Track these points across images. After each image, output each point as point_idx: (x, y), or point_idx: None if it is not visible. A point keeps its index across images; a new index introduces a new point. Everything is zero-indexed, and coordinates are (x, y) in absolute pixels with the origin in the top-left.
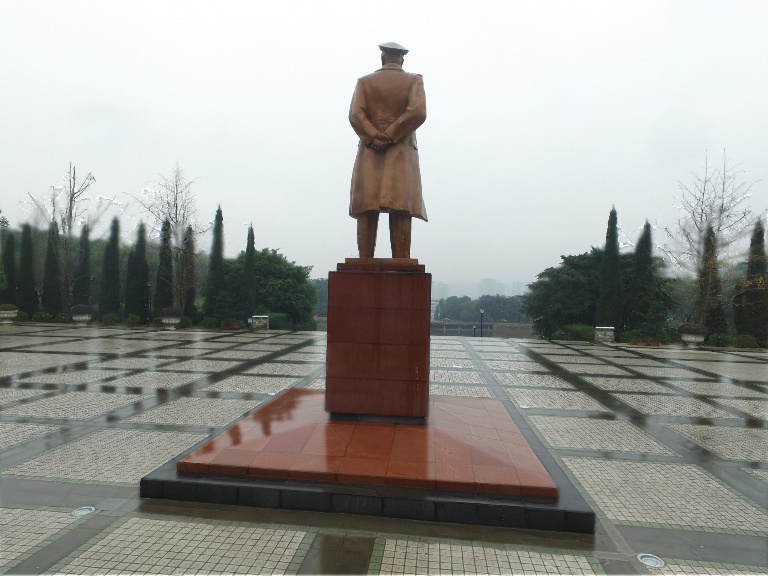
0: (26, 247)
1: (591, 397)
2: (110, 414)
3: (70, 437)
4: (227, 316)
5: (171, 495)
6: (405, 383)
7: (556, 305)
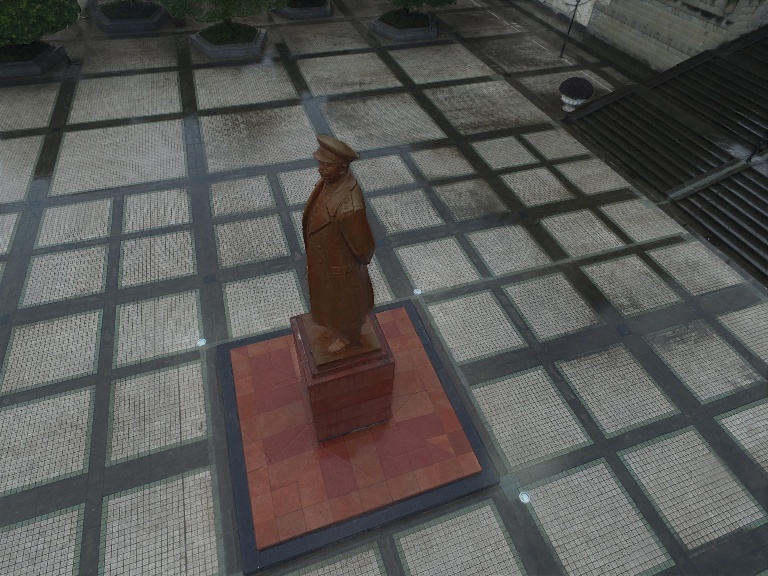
0: None
1: (144, 300)
2: None
3: None
4: None
5: None
6: None
7: None
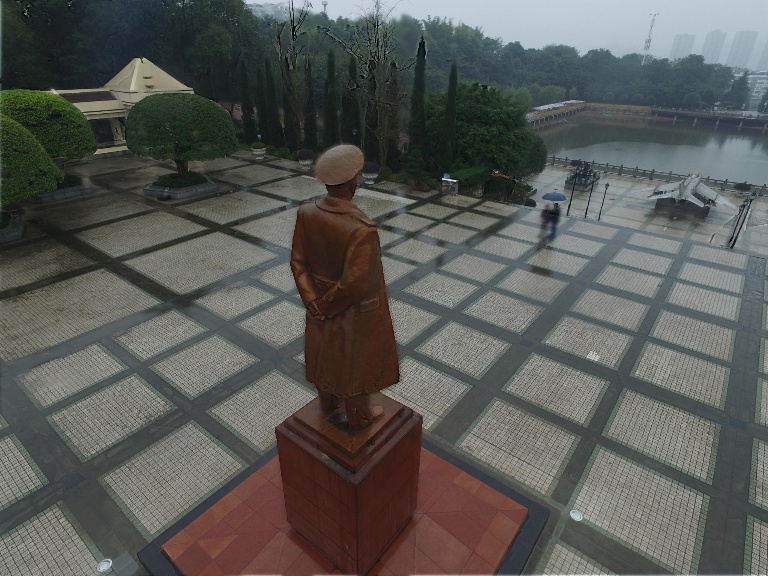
0: (269, 82)
1: (704, 521)
2: (210, 393)
3: (165, 430)
4: (418, 176)
5: (150, 575)
6: (339, 548)
7: None
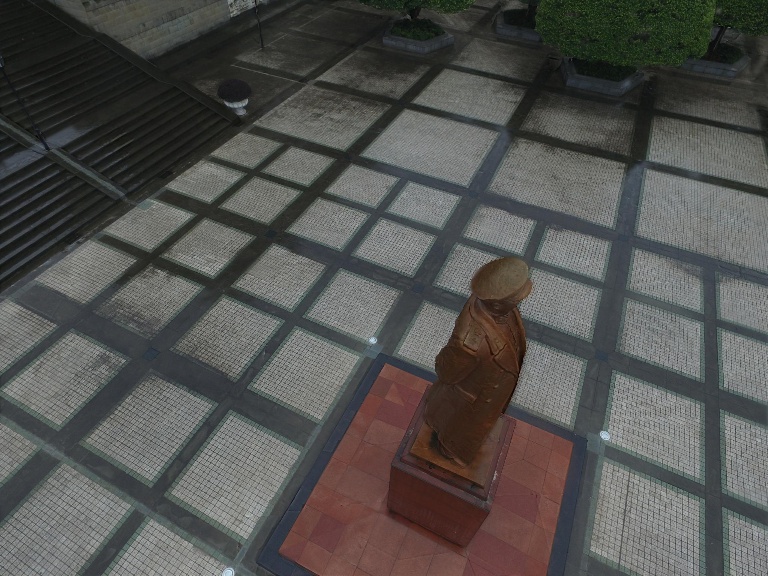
0: None
1: None
2: (528, 323)
3: None
4: None
5: None
6: None
7: None
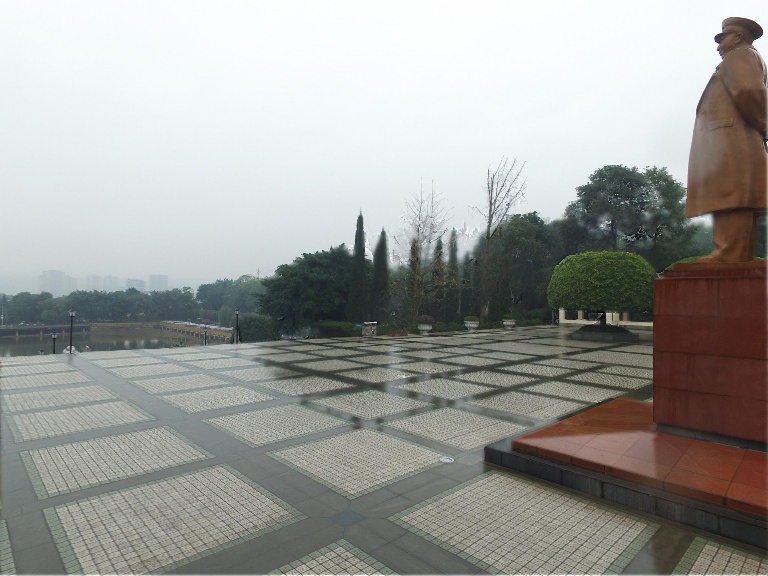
0: None
1: None
2: None
3: None
4: None
5: None
6: None
7: (310, 303)
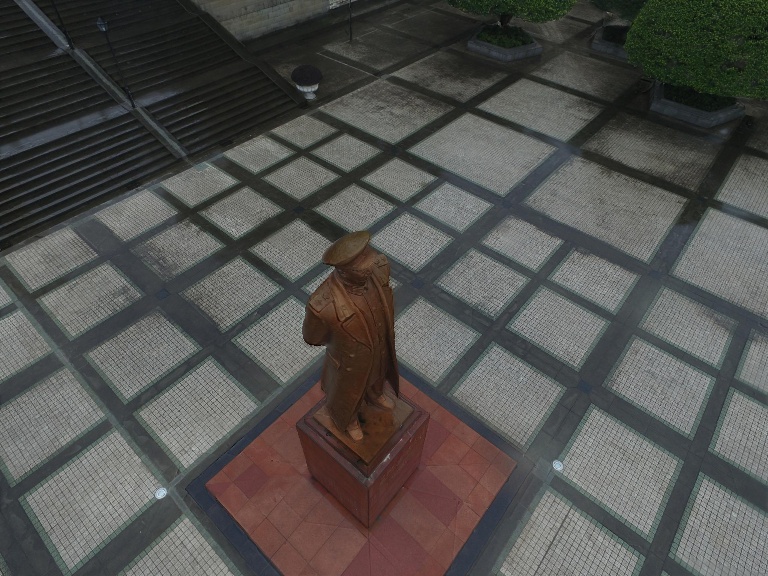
0: None
1: None
2: (517, 339)
3: (468, 320)
4: None
5: None
6: None
7: None
